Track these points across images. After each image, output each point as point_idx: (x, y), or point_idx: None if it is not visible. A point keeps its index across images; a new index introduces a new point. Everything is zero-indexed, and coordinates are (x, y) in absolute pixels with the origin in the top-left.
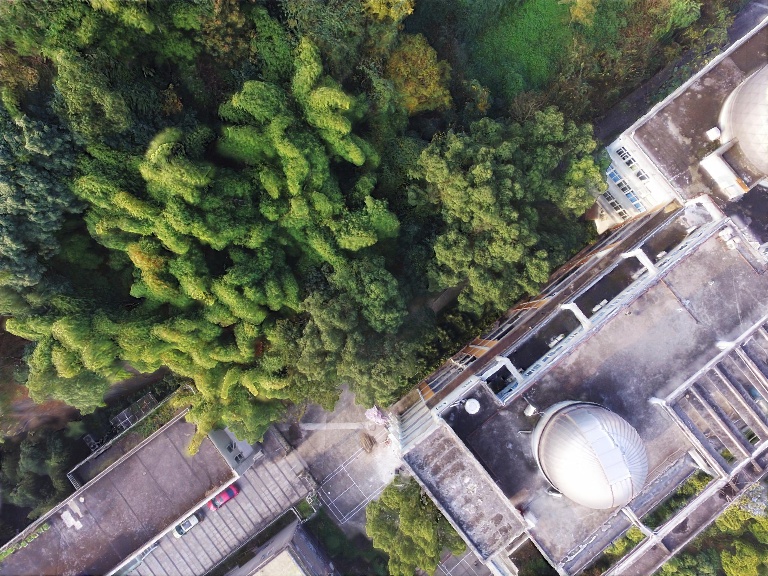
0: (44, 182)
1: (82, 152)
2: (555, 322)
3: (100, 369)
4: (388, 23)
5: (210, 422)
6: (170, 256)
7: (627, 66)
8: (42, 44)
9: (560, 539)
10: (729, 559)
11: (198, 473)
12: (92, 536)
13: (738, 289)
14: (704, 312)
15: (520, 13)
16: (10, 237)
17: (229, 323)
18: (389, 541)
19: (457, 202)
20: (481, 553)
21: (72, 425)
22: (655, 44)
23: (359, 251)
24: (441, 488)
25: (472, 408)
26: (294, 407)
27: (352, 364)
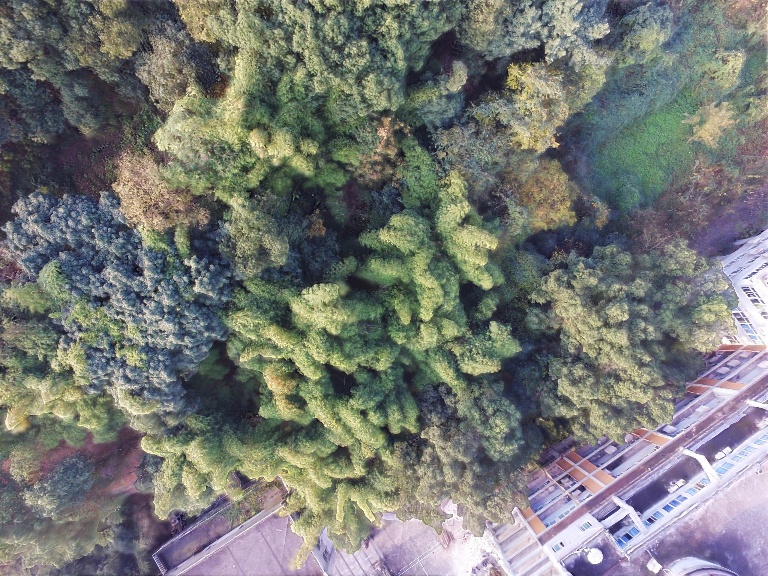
0: (204, 320)
1: (238, 286)
2: (675, 466)
3: None
4: (529, 152)
5: None
6: (300, 377)
7: (743, 186)
8: (214, 183)
9: None
10: None
11: (287, 570)
12: None
13: None
14: None
15: (640, 127)
16: (166, 372)
17: (349, 444)
18: None
19: (588, 340)
20: None
21: None
22: None
23: None
24: None
25: (596, 559)
26: None
27: (469, 495)
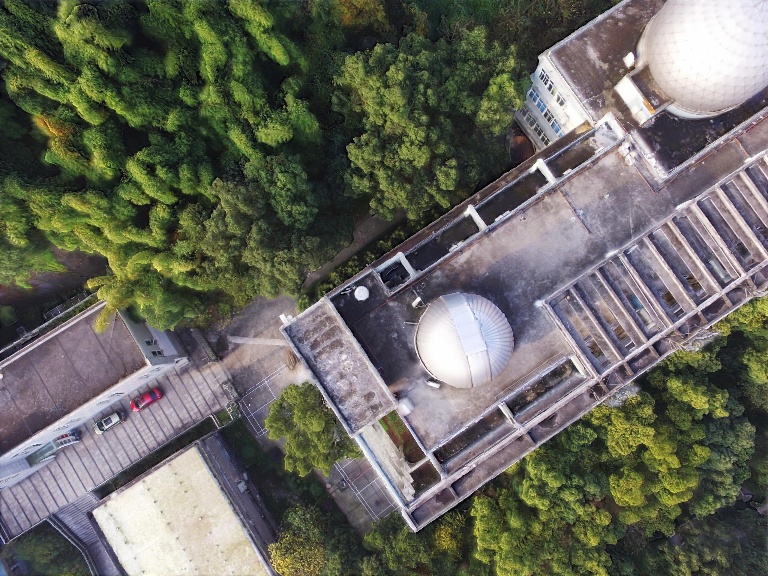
0: None
1: (0, 7)
2: (458, 229)
3: (15, 234)
4: None
5: (118, 298)
6: (87, 127)
7: (570, 7)
8: None
9: (435, 429)
10: (616, 482)
11: (114, 361)
12: (7, 411)
13: (633, 204)
14: (597, 224)
15: None
16: None
17: (141, 201)
18: (284, 433)
19: (369, 102)
20: (351, 427)
21: (2, 309)
22: None
23: (278, 149)
24: (319, 362)
25: (360, 294)
26: (218, 312)
27: (255, 250)
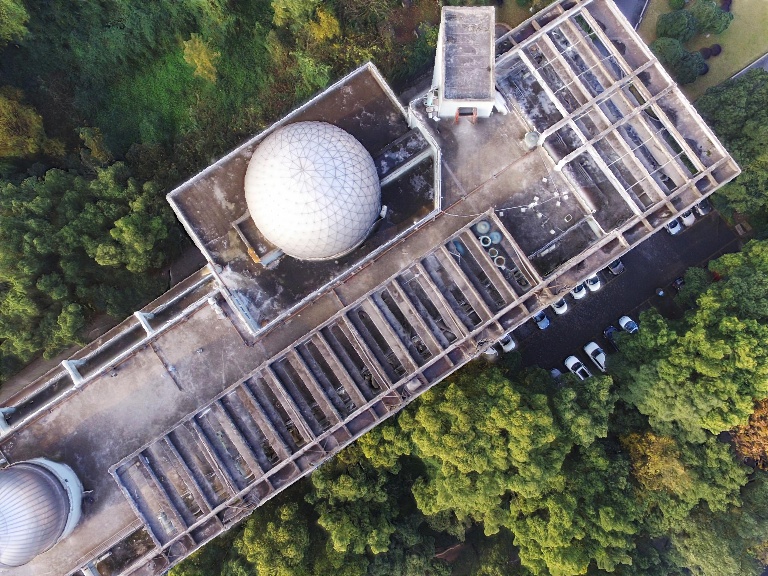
0: None
1: None
2: None
3: None
4: None
5: None
6: None
7: None
8: None
9: None
10: None
11: None
12: None
13: (226, 359)
14: (189, 380)
15: (157, 64)
16: None
17: None
18: None
19: None
20: None
21: None
22: (277, 103)
23: None
24: None
25: None
26: None
27: None
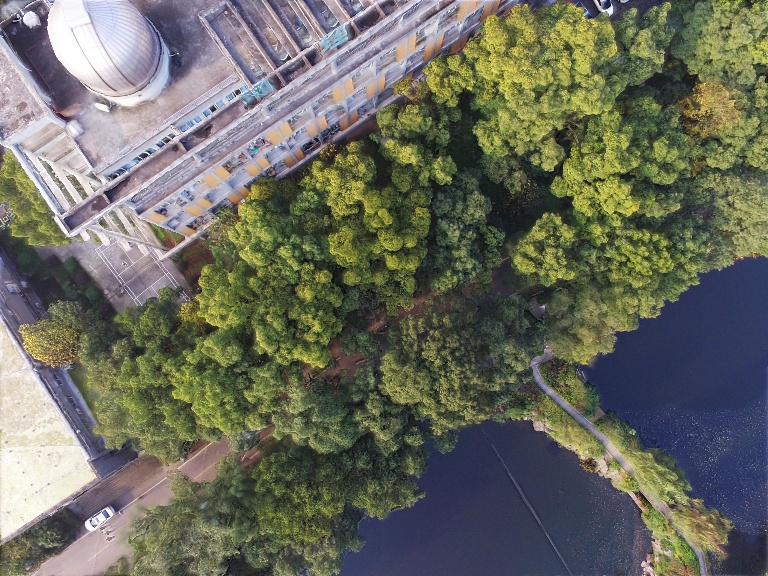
0: None
1: None
2: None
3: None
4: None
5: None
6: None
7: None
8: None
9: (106, 152)
10: (333, 240)
11: None
12: None
13: None
14: None
15: None
16: None
17: None
18: None
19: None
20: (2, 136)
21: None
22: None
23: None
24: None
25: (27, 18)
26: None
27: None
